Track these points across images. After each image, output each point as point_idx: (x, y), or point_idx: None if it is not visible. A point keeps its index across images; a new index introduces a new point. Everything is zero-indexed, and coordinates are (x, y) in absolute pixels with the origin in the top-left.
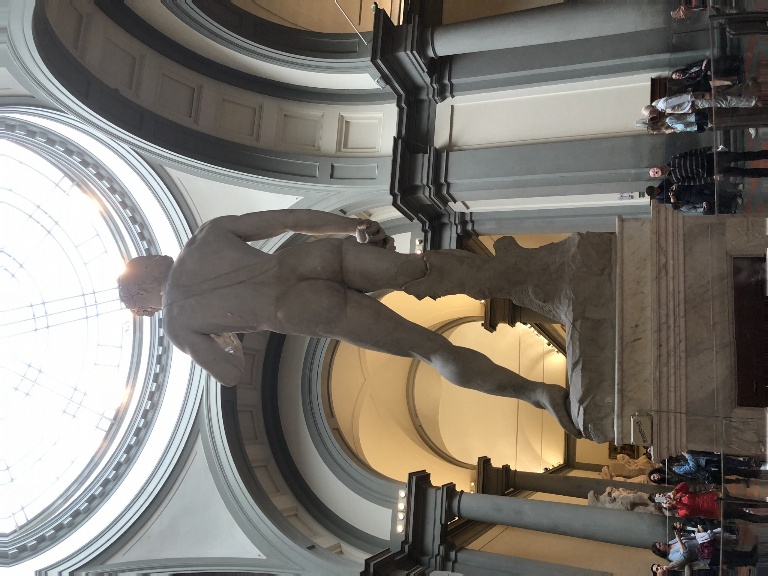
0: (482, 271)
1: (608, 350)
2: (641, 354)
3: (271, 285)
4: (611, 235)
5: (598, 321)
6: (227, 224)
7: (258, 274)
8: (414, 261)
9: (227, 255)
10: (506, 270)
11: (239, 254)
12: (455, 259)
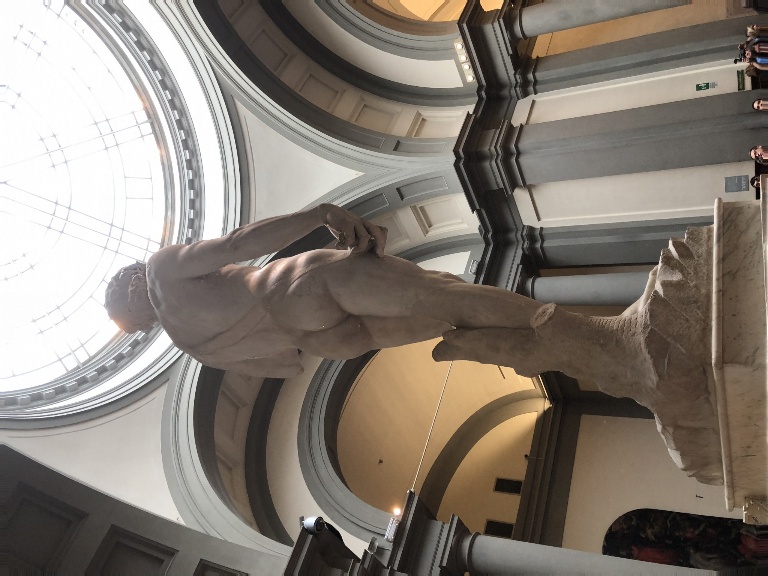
0: (527, 361)
1: (712, 447)
2: (755, 465)
3: (276, 331)
4: (704, 360)
5: (696, 430)
6: (175, 274)
7: (255, 325)
8: (428, 307)
9: (207, 317)
10: (559, 364)
11: (219, 313)
12: (486, 347)
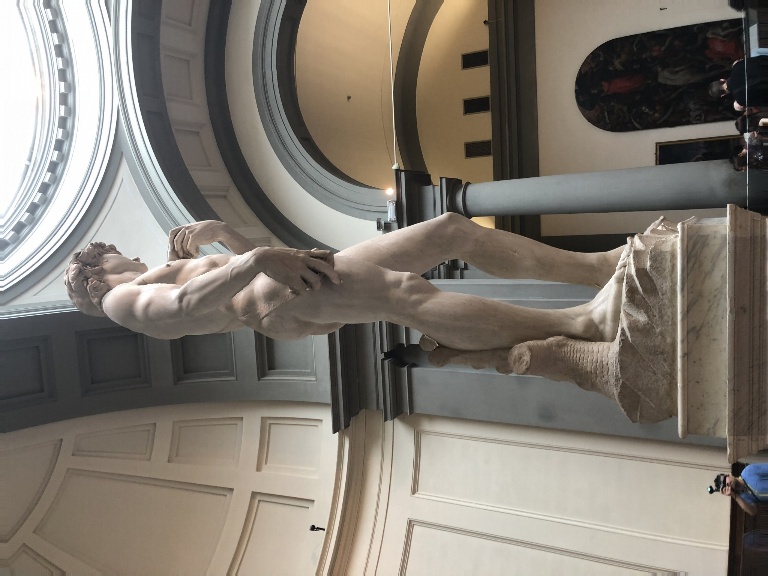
0: None
1: None
2: None
3: None
4: (672, 412)
5: None
6: None
7: None
8: None
9: None
10: None
11: None
12: None
